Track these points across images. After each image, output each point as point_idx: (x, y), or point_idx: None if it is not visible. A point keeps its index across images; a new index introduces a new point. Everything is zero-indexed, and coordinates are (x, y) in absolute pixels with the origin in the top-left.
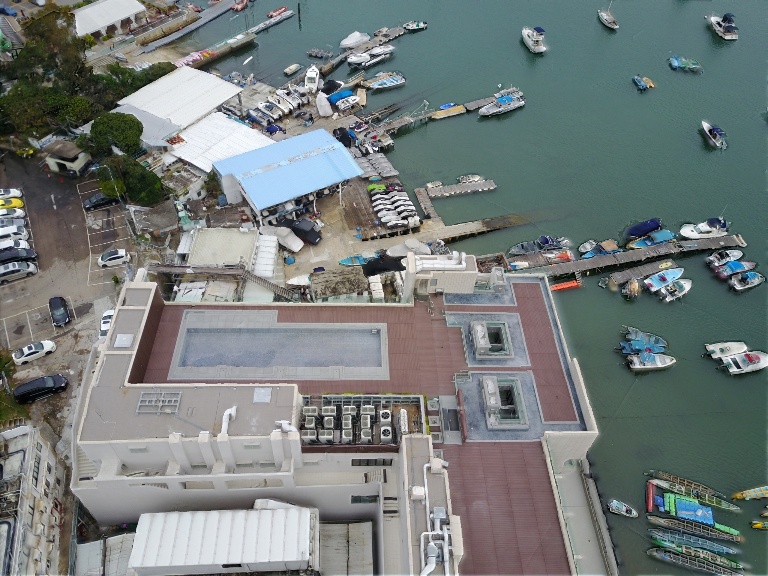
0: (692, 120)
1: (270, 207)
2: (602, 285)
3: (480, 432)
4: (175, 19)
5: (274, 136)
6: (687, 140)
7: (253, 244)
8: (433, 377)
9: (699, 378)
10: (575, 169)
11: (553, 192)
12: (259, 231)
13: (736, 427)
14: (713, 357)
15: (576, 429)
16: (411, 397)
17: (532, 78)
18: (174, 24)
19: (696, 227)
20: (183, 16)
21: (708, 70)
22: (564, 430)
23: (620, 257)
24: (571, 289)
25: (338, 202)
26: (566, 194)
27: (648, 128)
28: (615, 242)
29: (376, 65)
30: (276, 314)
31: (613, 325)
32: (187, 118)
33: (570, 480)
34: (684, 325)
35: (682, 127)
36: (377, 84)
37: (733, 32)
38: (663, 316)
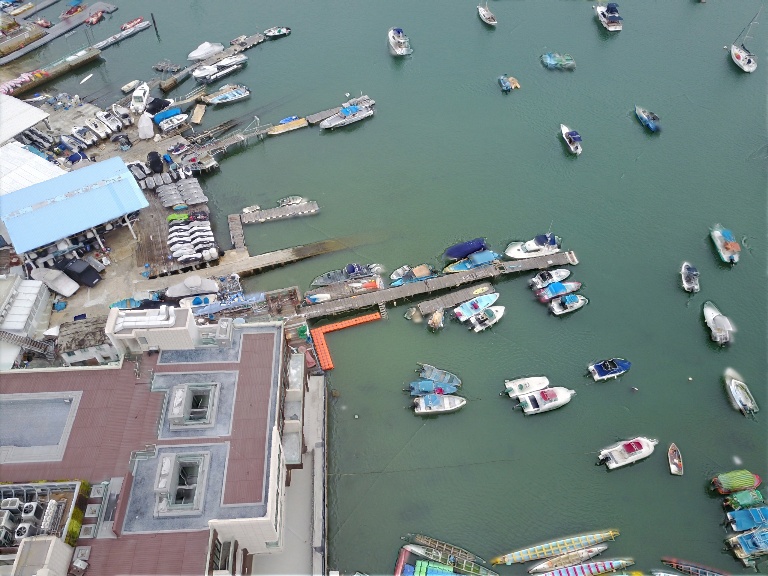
0: (552, 123)
1: (33, 250)
2: (407, 316)
3: (145, 521)
4: (14, 37)
5: (74, 165)
6: (545, 145)
7: (7, 293)
8: (113, 455)
9: (492, 420)
10: (413, 184)
11: (382, 211)
12: (30, 275)
13: (518, 477)
14: (510, 395)
15: (257, 512)
16: (67, 484)
17: (395, 83)
18: (14, 43)
19: (523, 245)
20: (24, 34)
21: (583, 66)
22: (243, 514)
23: (431, 284)
24: (372, 323)
25: (132, 236)
26: (396, 213)
27: (505, 133)
28: (430, 267)
29: (225, 77)
30: None
31: (409, 362)
32: None
33: (299, 555)
34: (489, 358)
35: (542, 131)
36: (218, 99)
37: (617, 22)
38: (468, 349)
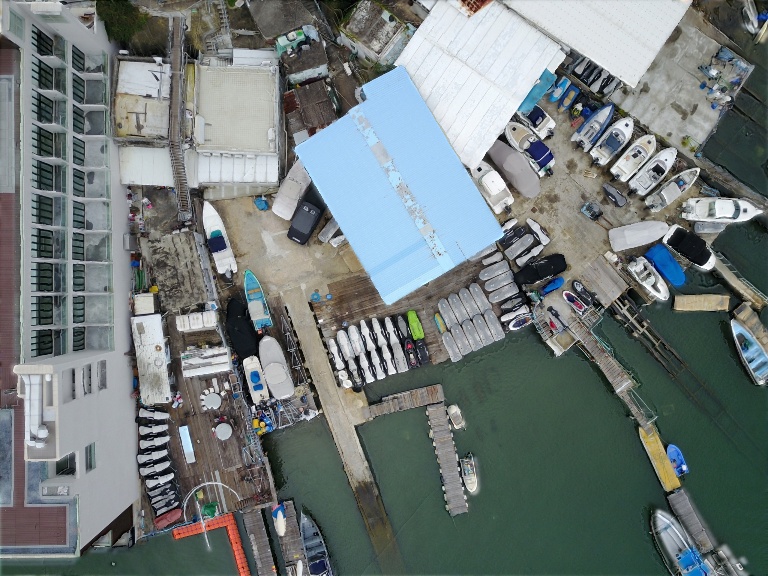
0: None
1: None
2: None
3: None
4: None
5: (517, 156)
6: None
7: None
8: None
9: None
10: None
11: None
12: None
13: None
14: None
15: None
16: None
17: None
18: None
19: None
20: None
21: None
22: None
23: None
24: None
25: None
26: None
27: None
28: None
29: None
30: (8, 191)
31: None
32: (535, 5)
33: None
34: None
35: None
36: (743, 332)
37: None
38: None
